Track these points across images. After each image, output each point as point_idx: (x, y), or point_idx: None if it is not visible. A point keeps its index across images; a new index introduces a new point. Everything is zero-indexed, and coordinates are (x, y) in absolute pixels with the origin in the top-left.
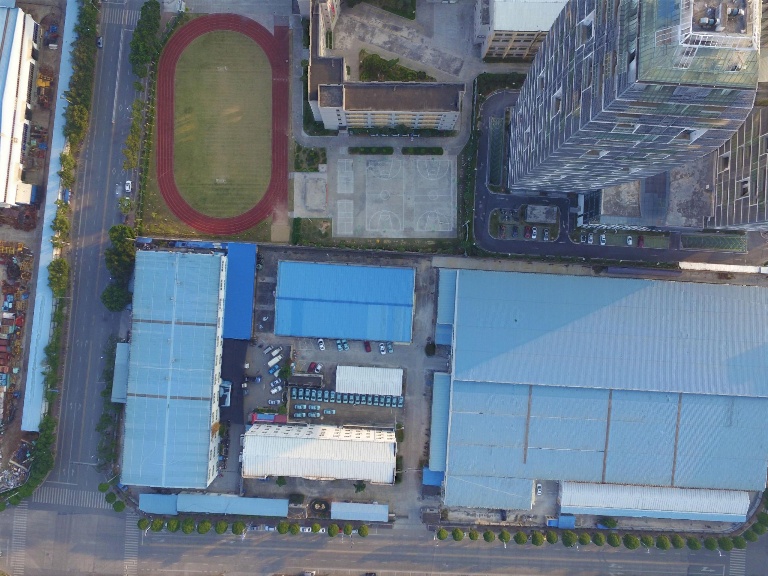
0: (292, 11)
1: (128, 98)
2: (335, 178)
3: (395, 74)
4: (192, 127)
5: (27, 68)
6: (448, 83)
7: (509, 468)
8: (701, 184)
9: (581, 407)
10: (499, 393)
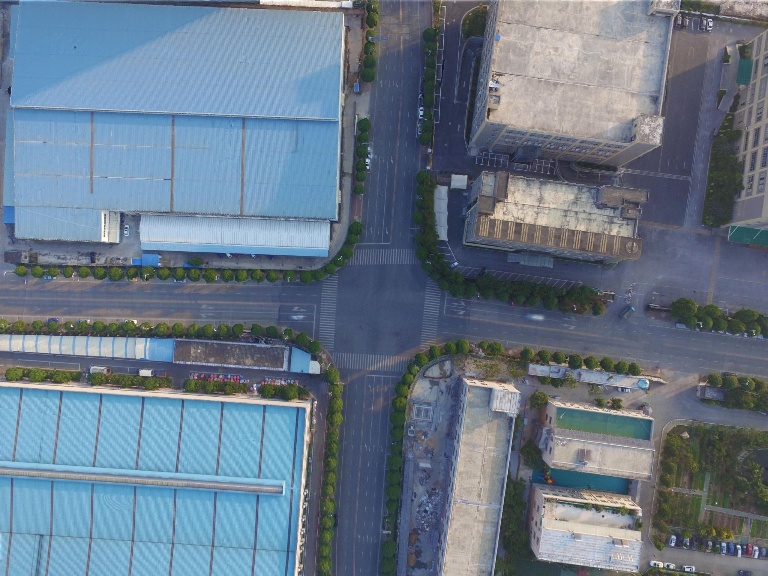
0: None
1: None
2: None
3: None
4: None
5: None
6: None
7: (76, 198)
8: None
9: (144, 134)
10: (61, 121)
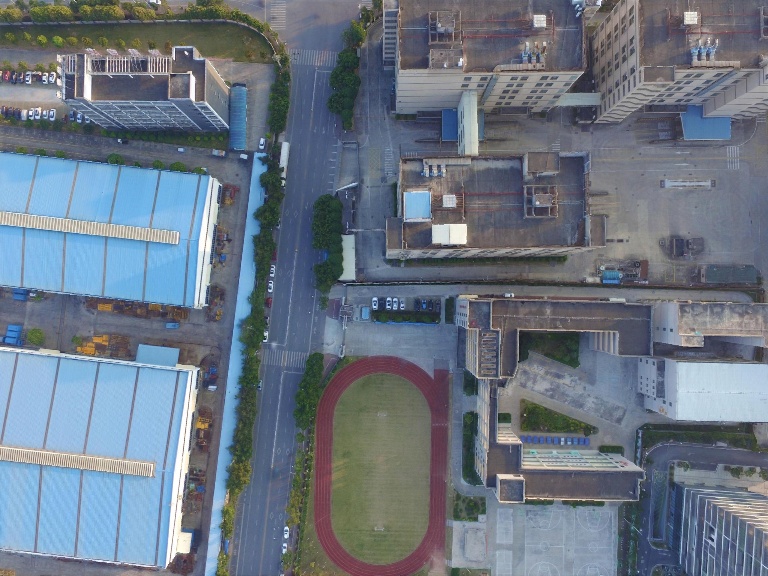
0: (457, 366)
1: (286, 441)
2: (494, 528)
3: None
4: (350, 472)
5: (190, 419)
6: (627, 470)
7: None
8: None
9: None
10: None
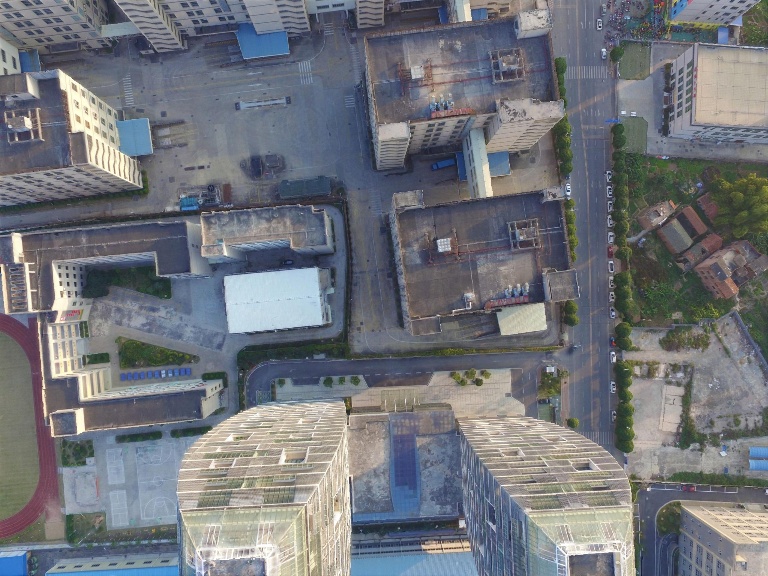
0: None
1: None
2: (105, 469)
3: (156, 357)
4: None
5: None
6: (189, 390)
7: None
8: (452, 470)
9: None
10: None
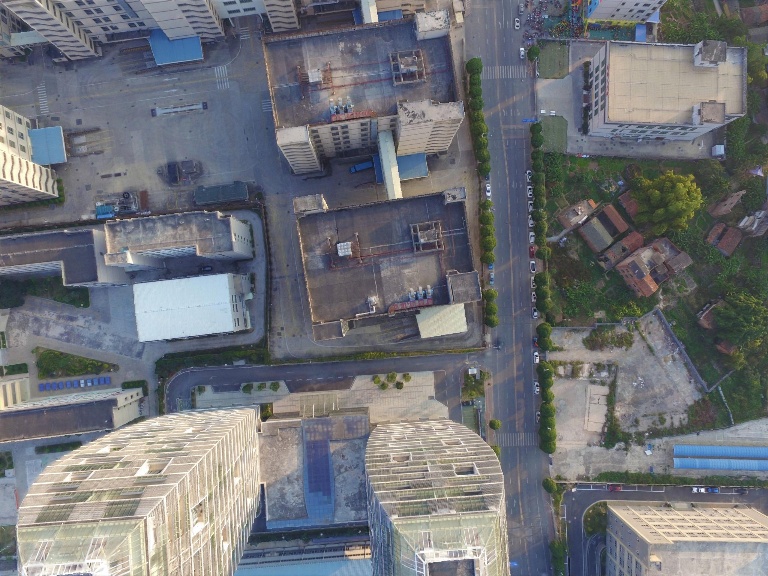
0: None
1: None
2: (25, 481)
3: (74, 367)
4: None
5: None
6: (100, 400)
7: None
8: None
9: None
10: None
